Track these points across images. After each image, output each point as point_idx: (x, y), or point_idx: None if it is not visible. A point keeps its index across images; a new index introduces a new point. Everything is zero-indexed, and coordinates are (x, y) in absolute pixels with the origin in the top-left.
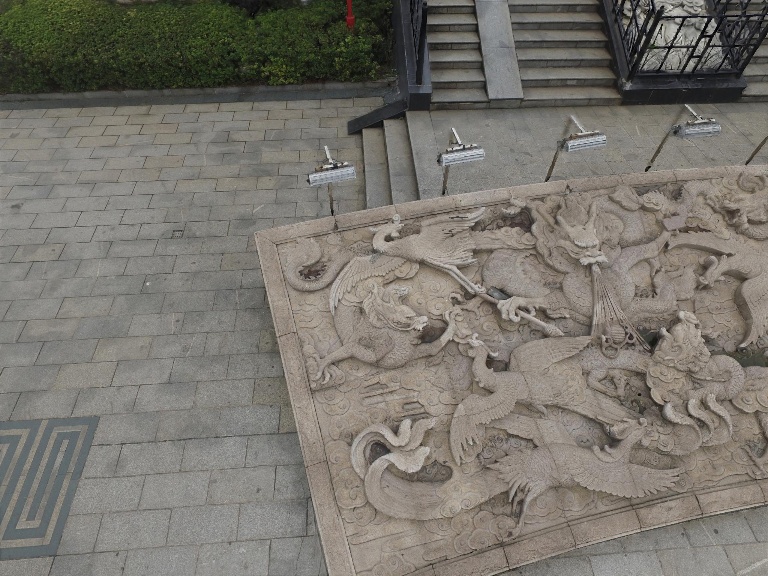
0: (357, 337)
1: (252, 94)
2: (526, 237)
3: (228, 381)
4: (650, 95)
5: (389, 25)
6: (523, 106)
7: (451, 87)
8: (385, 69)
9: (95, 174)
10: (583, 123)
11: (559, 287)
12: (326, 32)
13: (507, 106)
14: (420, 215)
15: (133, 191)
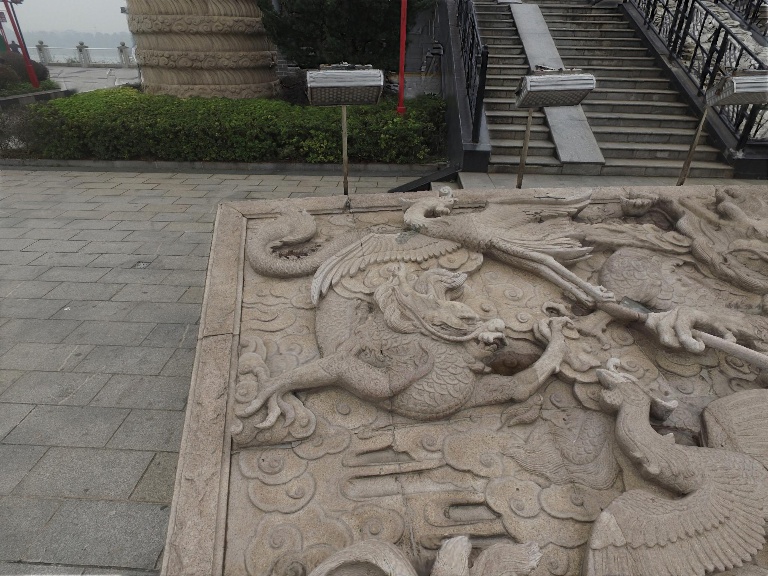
0: (355, 346)
1: (287, 171)
2: (671, 235)
3: (106, 451)
4: None
5: (442, 120)
6: (605, 174)
7: (513, 153)
8: (435, 157)
9: (81, 213)
10: None
11: (759, 313)
12: (374, 115)
13: (584, 173)
14: (483, 205)
15: (113, 227)
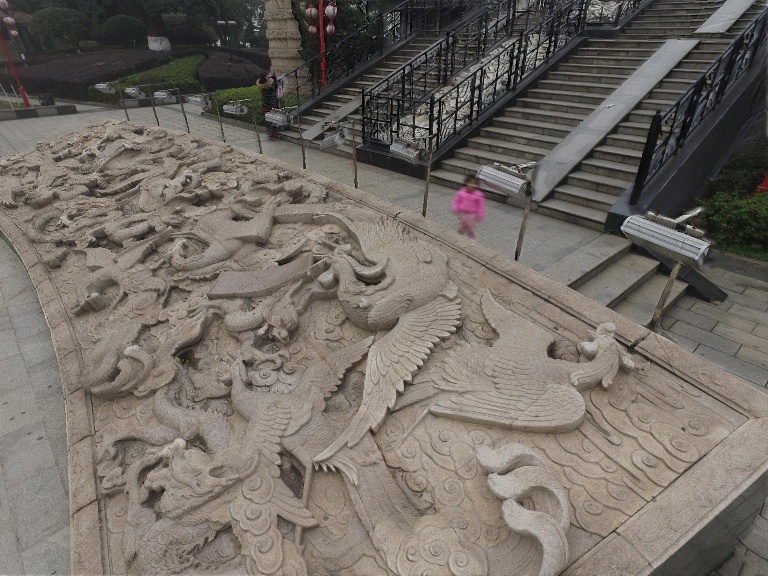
0: None
1: None
2: None
3: None
4: (371, 157)
5: None
6: (312, 147)
7: None
8: None
9: None
10: (314, 157)
11: None
12: None
13: (306, 145)
14: None
15: None
